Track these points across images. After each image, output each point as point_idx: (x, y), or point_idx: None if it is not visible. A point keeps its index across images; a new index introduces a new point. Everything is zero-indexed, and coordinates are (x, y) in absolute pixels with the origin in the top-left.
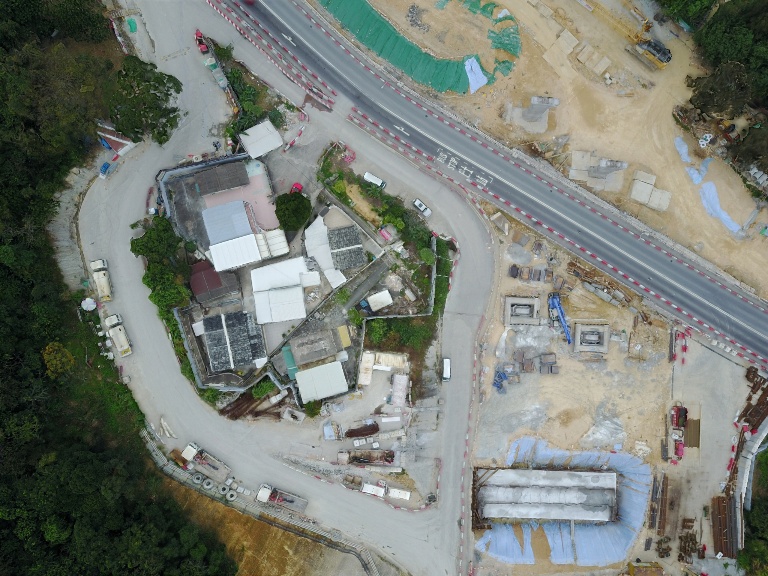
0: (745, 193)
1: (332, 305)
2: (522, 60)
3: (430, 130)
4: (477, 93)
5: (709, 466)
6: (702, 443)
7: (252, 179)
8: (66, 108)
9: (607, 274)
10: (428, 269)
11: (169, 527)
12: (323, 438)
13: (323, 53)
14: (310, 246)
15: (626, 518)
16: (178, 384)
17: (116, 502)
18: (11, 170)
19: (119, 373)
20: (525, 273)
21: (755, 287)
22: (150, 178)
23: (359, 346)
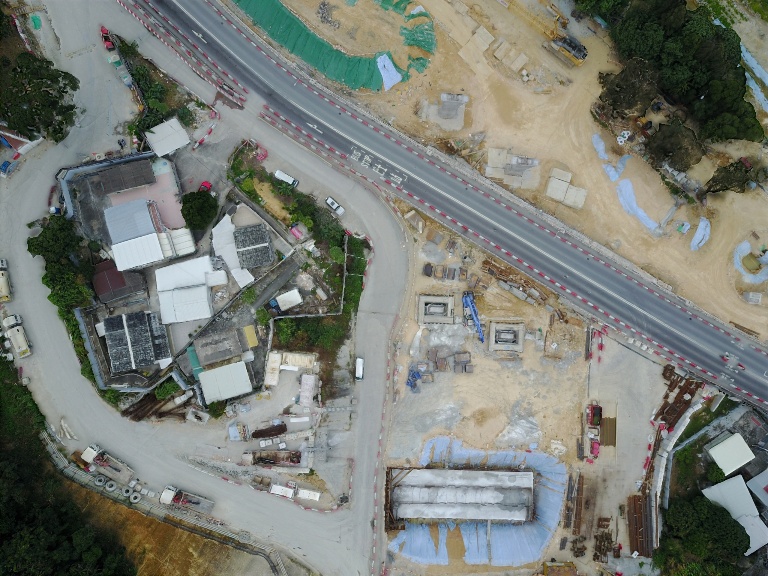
0: (663, 190)
1: (240, 304)
2: (437, 57)
3: (343, 128)
4: (392, 90)
5: (625, 465)
6: (618, 442)
7: (159, 177)
8: None
9: (523, 272)
10: (339, 268)
11: (63, 530)
12: (229, 439)
13: (234, 50)
14: (217, 245)
15: (542, 517)
16: (79, 385)
17: (6, 505)
18: None
19: (19, 374)
20: (439, 271)
21: (672, 285)
22: (53, 177)
23: None
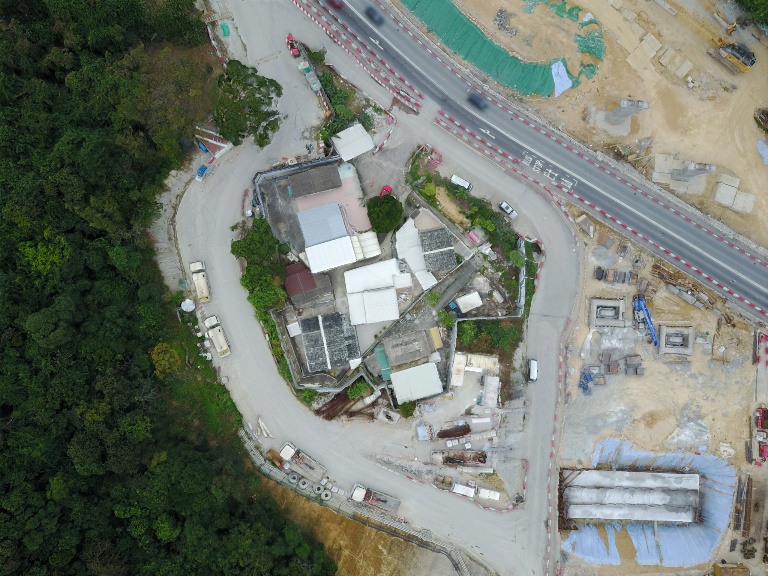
0: None
1: (423, 307)
2: (605, 63)
3: (515, 133)
4: (561, 96)
5: None
6: None
7: (343, 182)
8: (176, 112)
9: (691, 276)
10: (515, 271)
11: (273, 526)
12: (416, 438)
13: (410, 57)
14: (401, 248)
15: (710, 519)
16: (275, 384)
17: None
18: (119, 173)
19: (217, 373)
20: (610, 275)
21: None
22: (245, 180)
23: (449, 347)
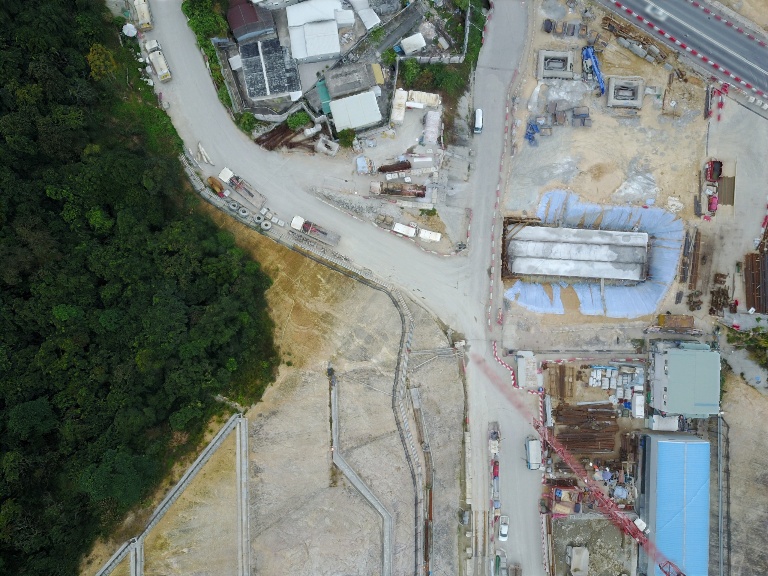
0: None
1: (366, 47)
2: None
3: None
4: None
5: (743, 223)
6: (736, 200)
7: None
8: None
9: (643, 30)
10: (461, 17)
11: None
12: (356, 172)
13: None
14: None
15: (657, 275)
16: (215, 112)
17: (157, 200)
18: None
19: (158, 100)
20: (559, 26)
21: None
22: None
23: (392, 88)
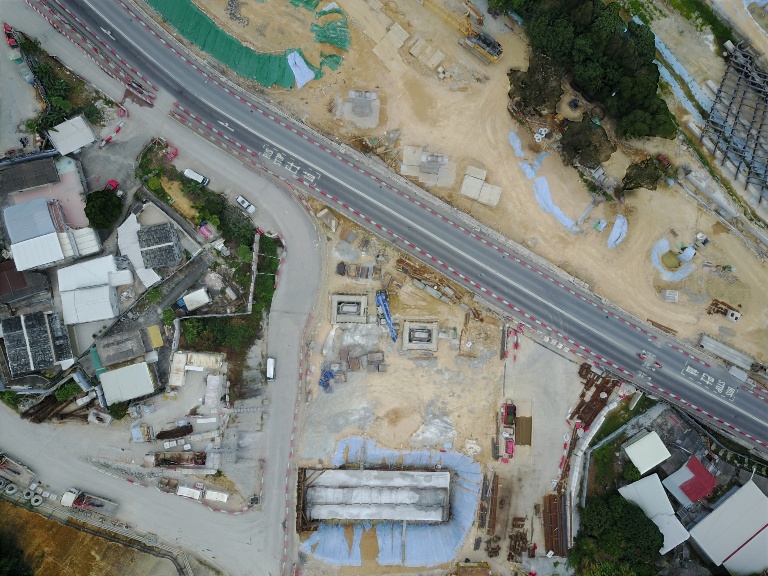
0: (581, 188)
1: (146, 304)
2: (352, 54)
3: (255, 125)
4: (305, 88)
5: (541, 464)
6: (534, 441)
7: (64, 176)
8: None
9: (437, 271)
10: (249, 267)
11: None
12: None
13: (144, 47)
14: (123, 244)
15: (458, 518)
16: None
17: None
18: None
19: None
20: (352, 270)
21: (589, 283)
22: None
23: (174, 346)
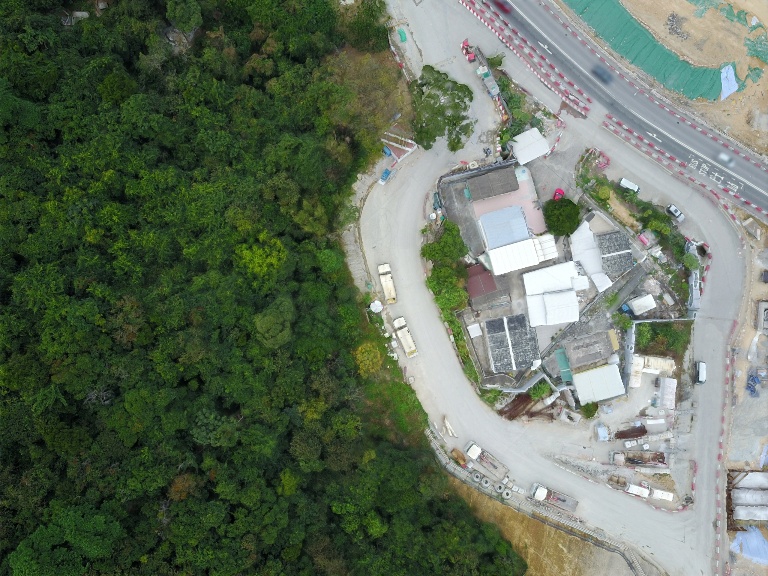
0: None
1: (597, 309)
2: None
3: (681, 136)
4: (727, 100)
5: None
6: None
7: None
8: None
9: None
10: (686, 274)
11: None
12: (594, 439)
13: (578, 61)
14: (576, 251)
15: None
16: (459, 385)
17: (426, 499)
18: (323, 177)
19: (403, 373)
20: None
21: None
22: (425, 184)
23: (623, 349)
